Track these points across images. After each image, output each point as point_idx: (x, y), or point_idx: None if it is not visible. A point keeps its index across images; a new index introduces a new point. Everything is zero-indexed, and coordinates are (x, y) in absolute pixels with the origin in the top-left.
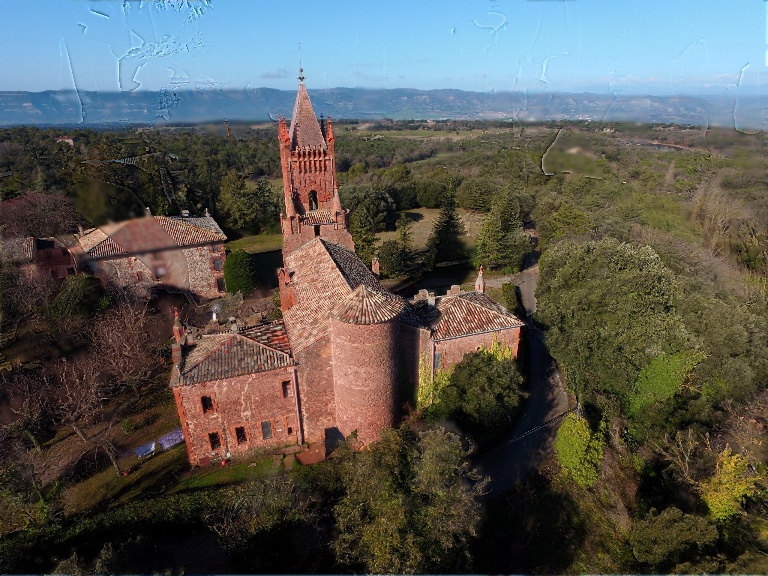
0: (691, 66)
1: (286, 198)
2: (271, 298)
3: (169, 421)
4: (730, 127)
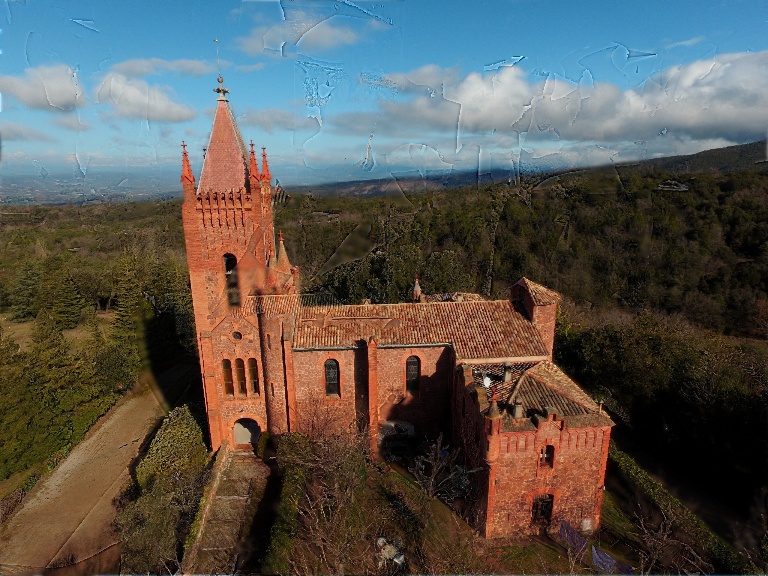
0: (241, 134)
1: (216, 272)
2: (5, 541)
3: (513, 569)
4: (317, 175)
